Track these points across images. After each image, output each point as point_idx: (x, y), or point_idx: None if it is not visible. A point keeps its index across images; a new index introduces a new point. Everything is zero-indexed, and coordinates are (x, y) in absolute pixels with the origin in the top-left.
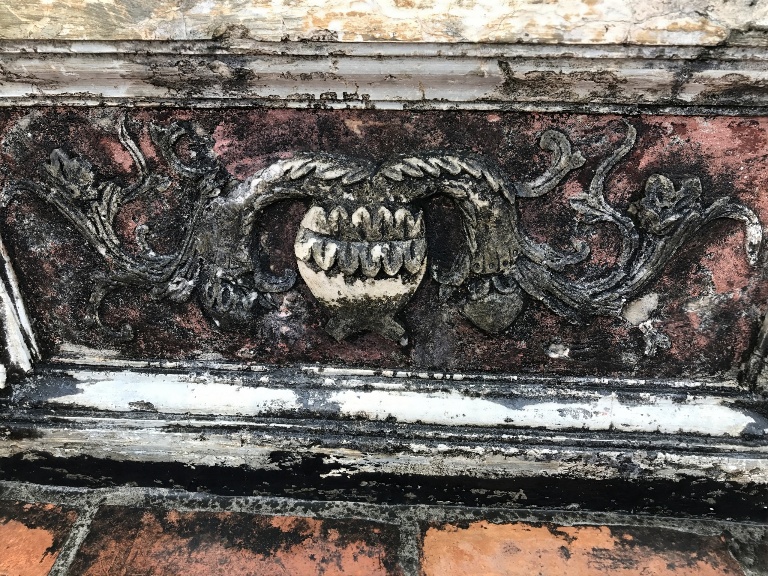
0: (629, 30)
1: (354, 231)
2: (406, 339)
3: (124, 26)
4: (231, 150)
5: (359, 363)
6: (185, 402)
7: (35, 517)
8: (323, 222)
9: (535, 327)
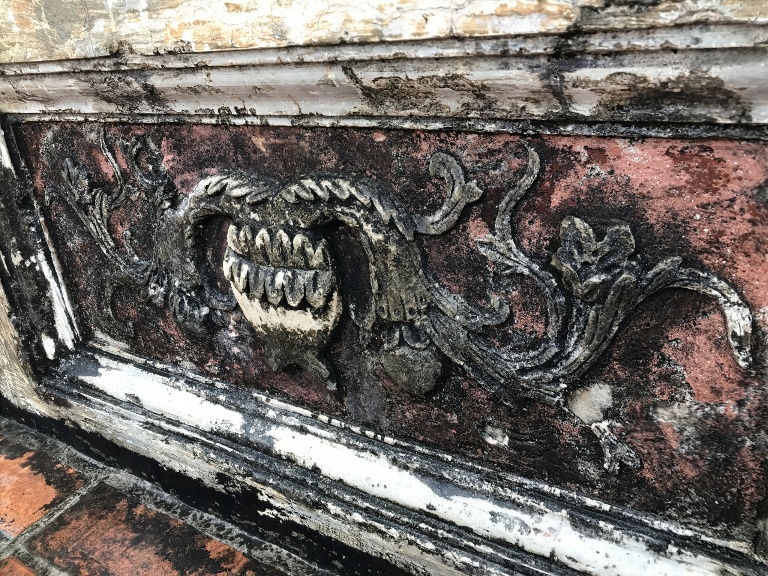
0: (452, 18)
1: (258, 253)
2: (334, 383)
3: (58, 47)
4: (175, 165)
5: (301, 401)
6: (161, 403)
7: (56, 476)
8: (235, 241)
9: (465, 399)
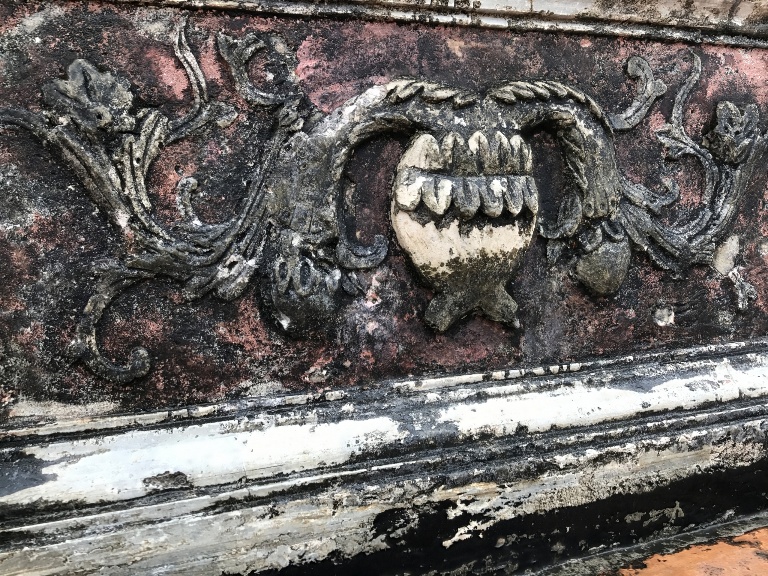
0: None
1: (472, 160)
2: (517, 319)
3: None
4: (317, 73)
5: (462, 368)
6: (238, 460)
7: None
8: (435, 152)
9: (640, 289)
